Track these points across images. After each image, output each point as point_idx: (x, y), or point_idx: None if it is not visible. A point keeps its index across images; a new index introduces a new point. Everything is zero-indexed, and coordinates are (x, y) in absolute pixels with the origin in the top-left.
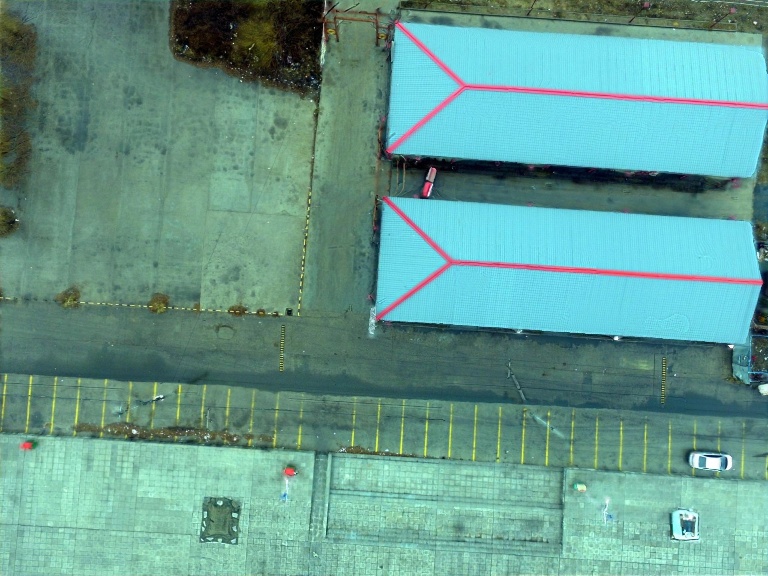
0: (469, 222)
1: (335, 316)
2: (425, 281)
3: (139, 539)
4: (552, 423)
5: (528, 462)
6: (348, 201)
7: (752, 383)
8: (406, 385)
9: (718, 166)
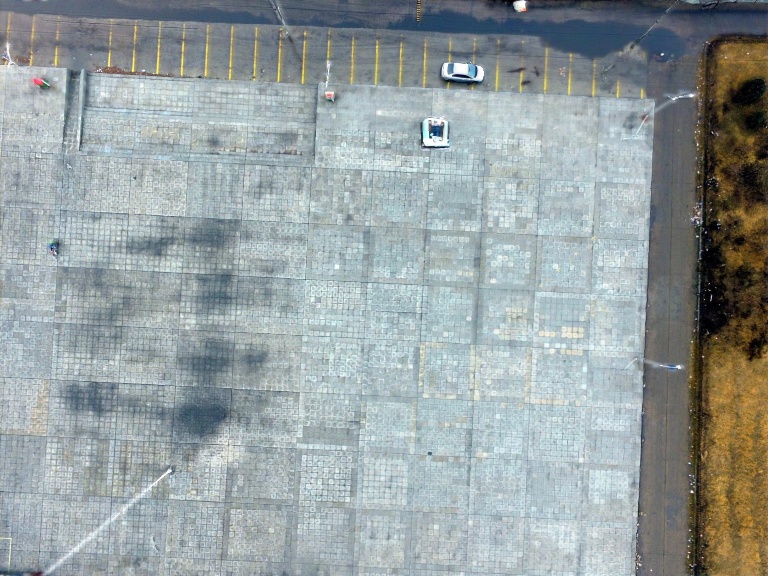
0: None
1: None
2: None
3: None
4: (308, 42)
5: (284, 80)
6: None
7: None
8: (162, 7)
9: None
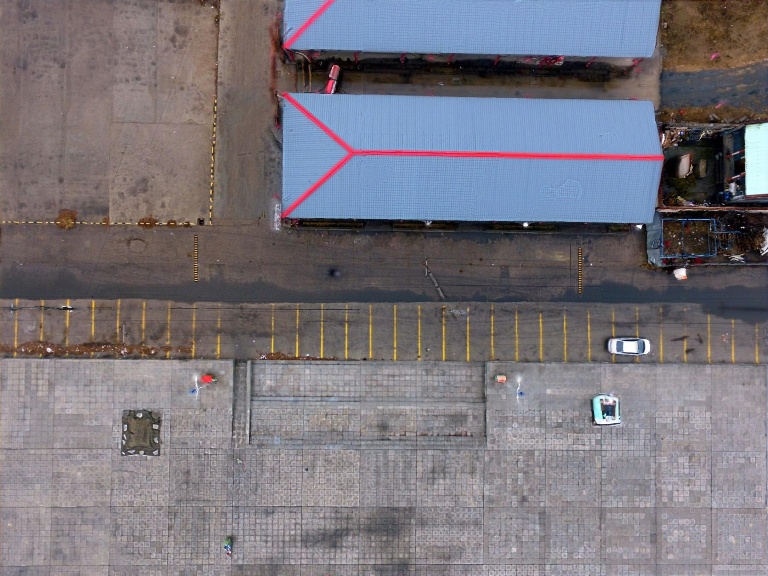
0: (371, 114)
1: (248, 223)
2: (329, 174)
3: (59, 456)
4: (472, 319)
5: (449, 359)
6: (255, 107)
7: (667, 268)
8: (324, 289)
9: (618, 47)
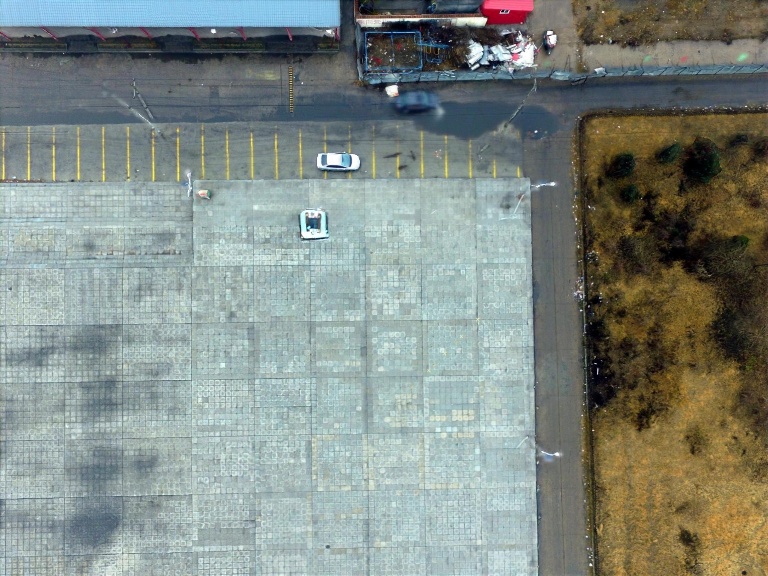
0: None
1: None
2: None
3: None
4: (181, 139)
5: (159, 179)
6: None
7: (378, 85)
8: (30, 111)
9: None
